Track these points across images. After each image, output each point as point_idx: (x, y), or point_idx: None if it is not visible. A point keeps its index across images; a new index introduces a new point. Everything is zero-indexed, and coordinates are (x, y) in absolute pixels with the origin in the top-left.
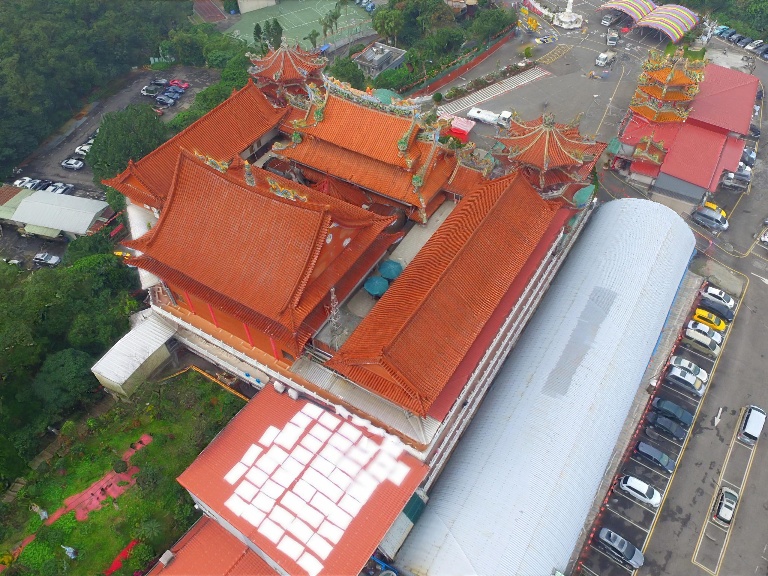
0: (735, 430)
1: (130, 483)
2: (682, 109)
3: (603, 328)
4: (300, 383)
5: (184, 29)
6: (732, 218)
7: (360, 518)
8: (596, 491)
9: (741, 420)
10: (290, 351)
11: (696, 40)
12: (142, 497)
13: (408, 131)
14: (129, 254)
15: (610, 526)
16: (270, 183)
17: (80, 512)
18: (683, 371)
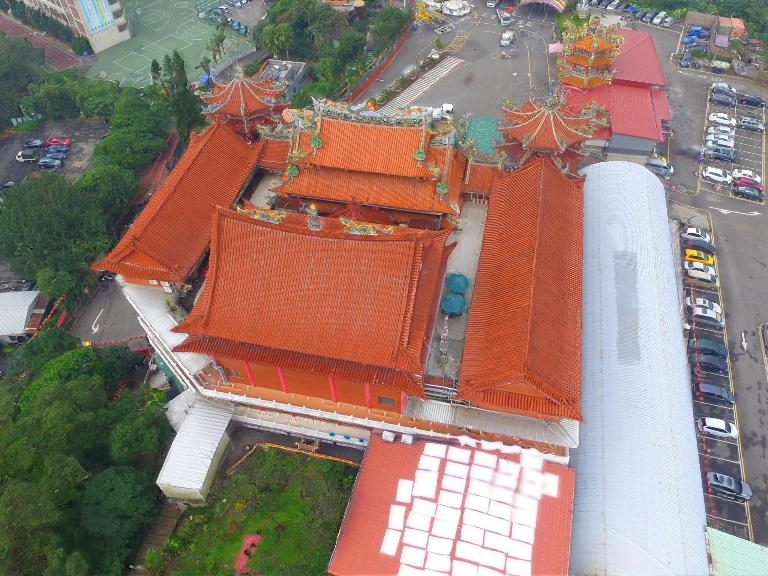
0: (762, 349)
1: None
2: (606, 72)
3: (640, 288)
4: (410, 425)
5: (42, 81)
6: (671, 162)
7: (539, 543)
8: (696, 441)
9: (763, 339)
10: (392, 395)
11: (577, 8)
12: None
13: (422, 140)
14: (88, 342)
15: (707, 469)
16: (343, 223)
17: None
18: (703, 309)
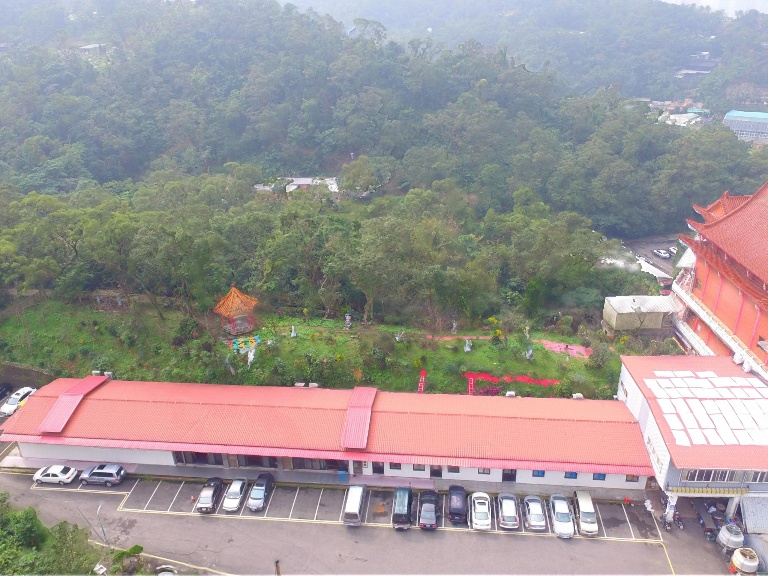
0: None
1: (584, 356)
2: None
3: None
4: None
5: None
6: None
7: (746, 448)
8: None
9: None
10: (767, 336)
11: None
12: (587, 364)
13: None
14: None
15: None
16: None
17: (547, 347)
18: None
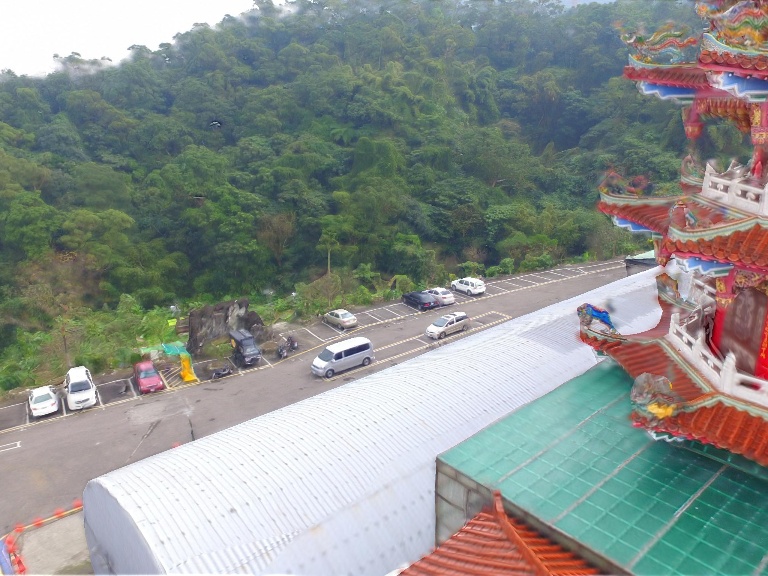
0: (368, 368)
1: None
2: None
3: None
4: None
5: None
6: None
7: None
8: None
9: (348, 372)
10: None
11: None
12: None
13: None
14: None
15: None
16: None
17: None
18: None
